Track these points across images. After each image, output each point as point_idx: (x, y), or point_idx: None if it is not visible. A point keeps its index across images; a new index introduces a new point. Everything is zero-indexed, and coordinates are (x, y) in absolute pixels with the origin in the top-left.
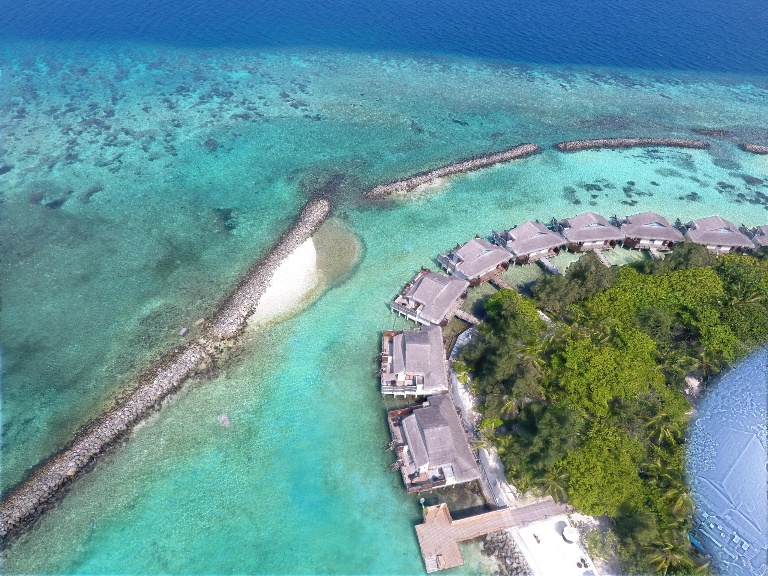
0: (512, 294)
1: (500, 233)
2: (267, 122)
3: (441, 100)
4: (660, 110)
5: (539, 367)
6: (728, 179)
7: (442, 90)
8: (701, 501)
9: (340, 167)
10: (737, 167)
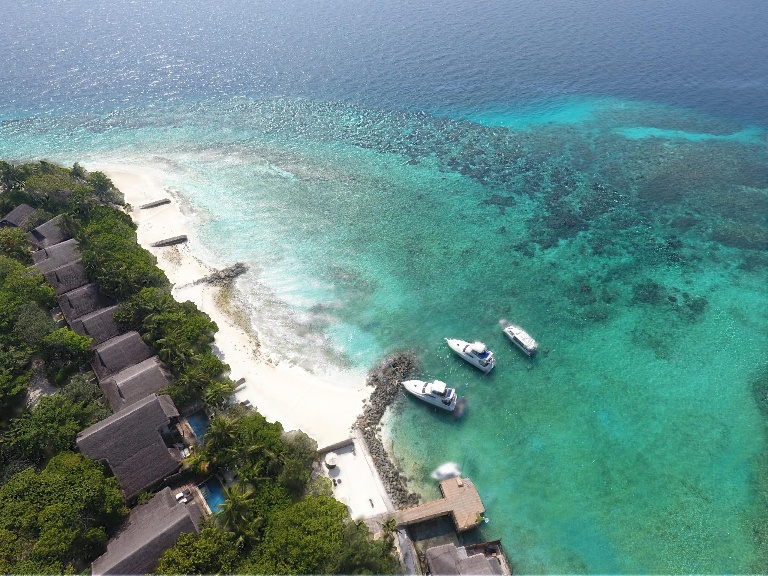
0: None
1: None
2: None
3: None
4: None
5: None
6: None
7: None
8: (208, 516)
9: None
10: None
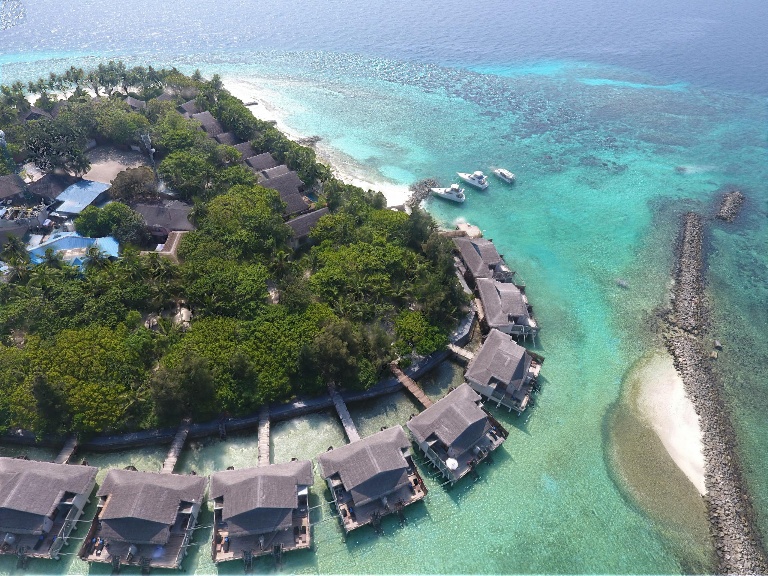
0: (424, 340)
1: (412, 501)
2: None
3: None
4: None
5: None
6: None
7: None
8: None
9: None
10: None
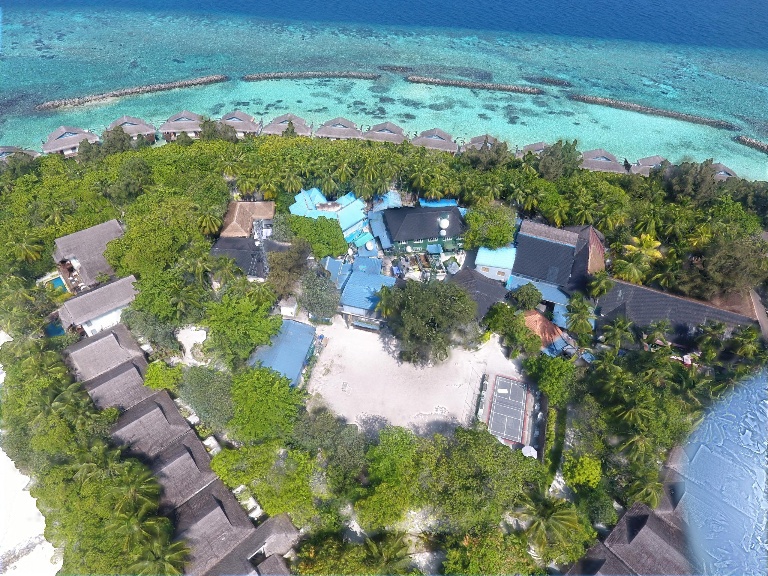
0: (53, 156)
1: None
2: (2, 60)
3: (179, 46)
4: (369, 54)
5: (6, 189)
6: (366, 99)
7: (188, 39)
8: (52, 257)
9: (34, 90)
10: (385, 91)
